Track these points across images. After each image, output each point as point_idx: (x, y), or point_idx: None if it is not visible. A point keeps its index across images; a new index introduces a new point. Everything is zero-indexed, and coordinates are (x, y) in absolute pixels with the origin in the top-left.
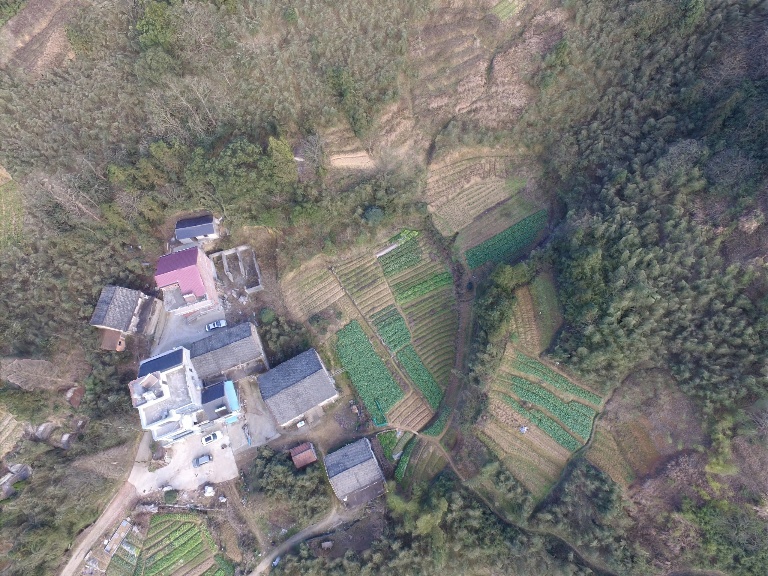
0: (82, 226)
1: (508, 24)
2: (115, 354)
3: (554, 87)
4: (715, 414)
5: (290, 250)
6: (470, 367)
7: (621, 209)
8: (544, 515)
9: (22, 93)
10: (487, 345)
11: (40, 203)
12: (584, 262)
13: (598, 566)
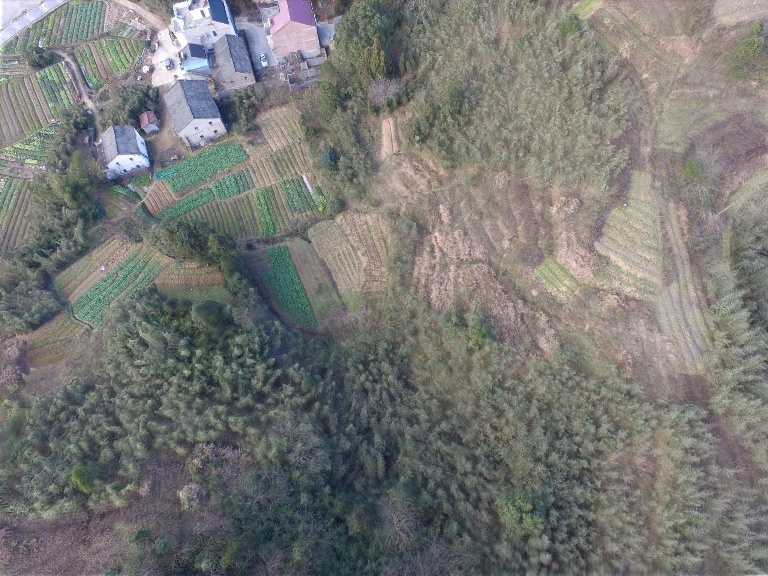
0: None
1: (531, 278)
2: None
3: None
4: None
5: None
6: None
7: (258, 367)
8: (35, 273)
9: None
10: None
11: None
12: None
13: None
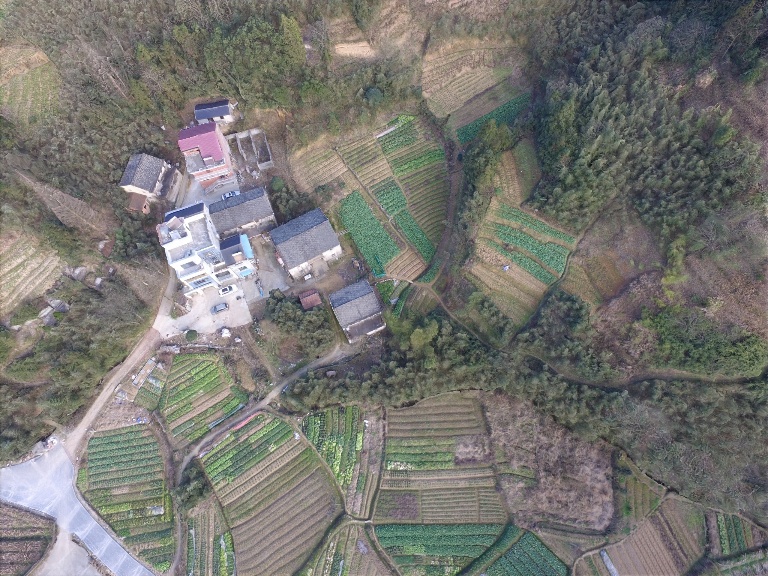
0: (112, 101)
1: None
2: (142, 212)
3: None
4: (671, 239)
5: (298, 128)
6: (459, 216)
7: (594, 76)
8: (523, 334)
9: None
10: (474, 192)
11: (74, 81)
12: (559, 114)
13: (570, 377)
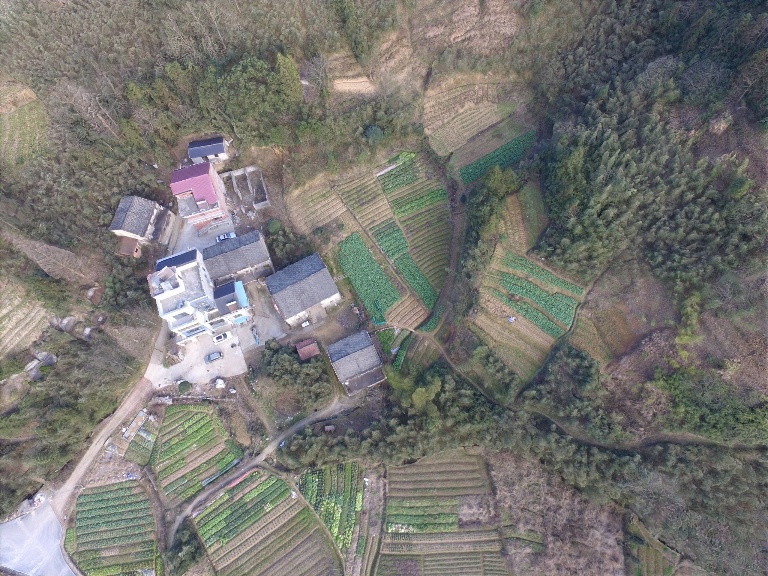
0: (102, 141)
1: None
2: (133, 257)
3: (543, 17)
4: (685, 294)
5: (295, 167)
6: (462, 264)
7: (603, 119)
8: (529, 392)
9: (45, 18)
10: (478, 241)
11: (62, 120)
12: (567, 161)
13: (578, 437)
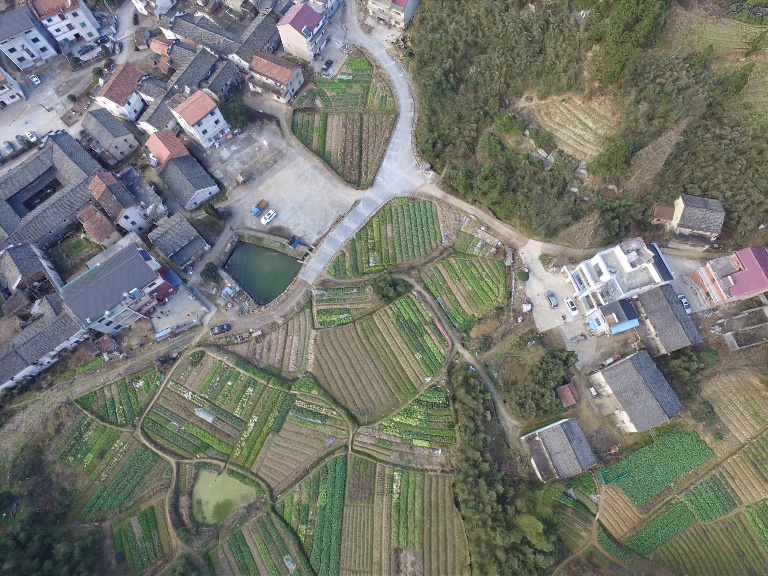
0: None
1: None
2: (653, 219)
3: None
4: None
5: None
6: None
7: None
8: None
9: None
10: None
11: None
12: None
13: None
